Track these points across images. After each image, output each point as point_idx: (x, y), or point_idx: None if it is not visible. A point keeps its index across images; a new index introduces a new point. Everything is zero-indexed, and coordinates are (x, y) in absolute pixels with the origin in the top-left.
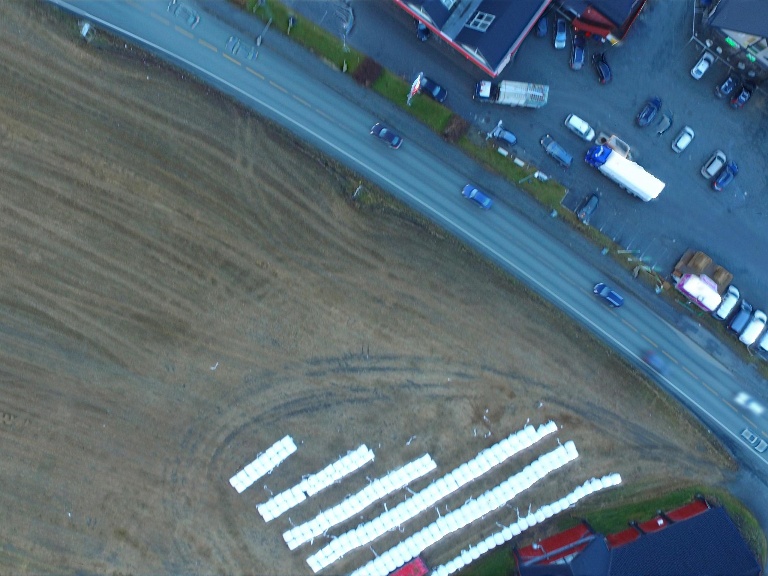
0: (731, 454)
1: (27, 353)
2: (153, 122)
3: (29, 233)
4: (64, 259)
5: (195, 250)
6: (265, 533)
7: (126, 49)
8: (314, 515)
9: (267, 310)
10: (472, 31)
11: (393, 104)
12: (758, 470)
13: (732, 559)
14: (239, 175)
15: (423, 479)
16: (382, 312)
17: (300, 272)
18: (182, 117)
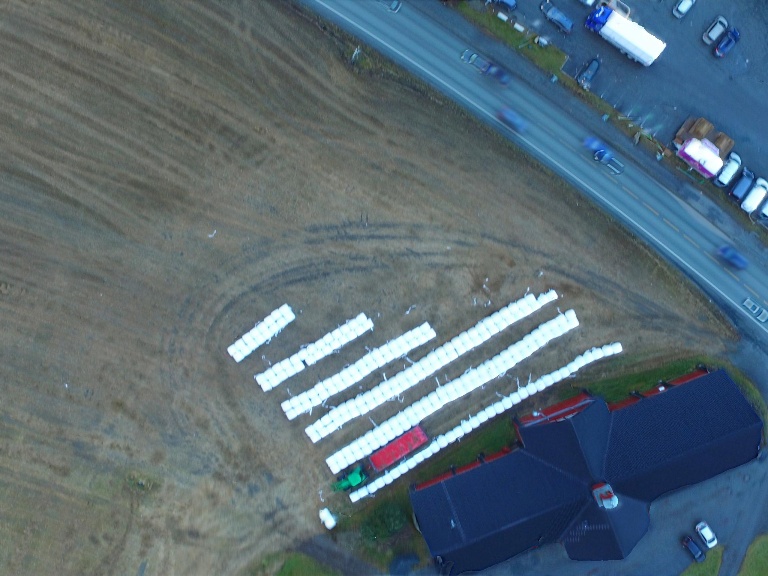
0: (733, 324)
1: (24, 221)
2: None
3: (25, 97)
4: (61, 124)
5: (193, 115)
6: (263, 404)
7: None
8: (313, 384)
9: (265, 177)
10: None
11: None
12: (760, 340)
13: (734, 416)
14: (237, 39)
15: (422, 348)
16: (381, 179)
17: (298, 138)
18: None
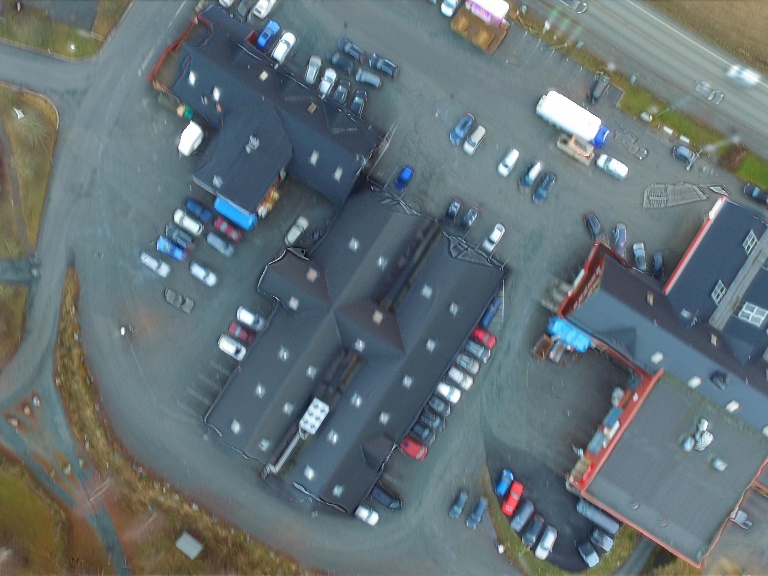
0: None
1: None
2: None
3: None
4: None
5: None
6: None
7: None
8: None
9: None
10: None
11: None
12: None
13: None
14: None
15: None
16: None
17: None
18: None
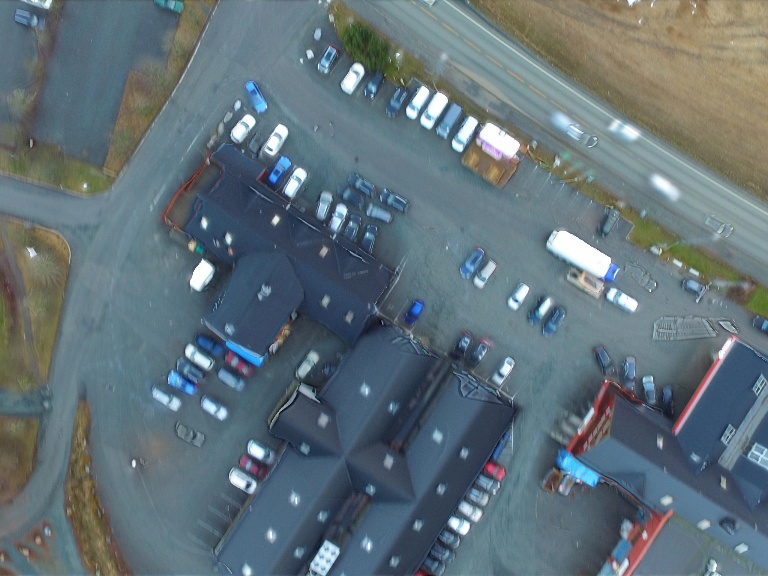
0: None
1: None
2: None
3: None
4: None
5: None
6: None
7: None
8: None
9: None
10: None
11: None
12: None
13: None
14: None
15: None
16: None
17: None
18: None
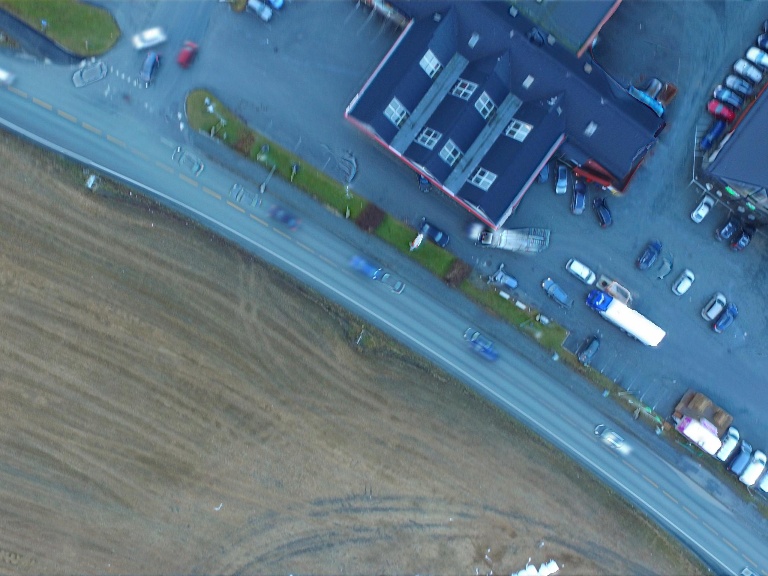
0: None
1: (33, 494)
2: (158, 268)
3: (35, 378)
4: (70, 403)
5: (199, 394)
6: None
7: (131, 197)
8: None
9: (271, 452)
10: (474, 188)
11: (395, 250)
12: None
13: None
14: (243, 320)
15: None
16: (385, 453)
17: (303, 415)
18: (186, 263)
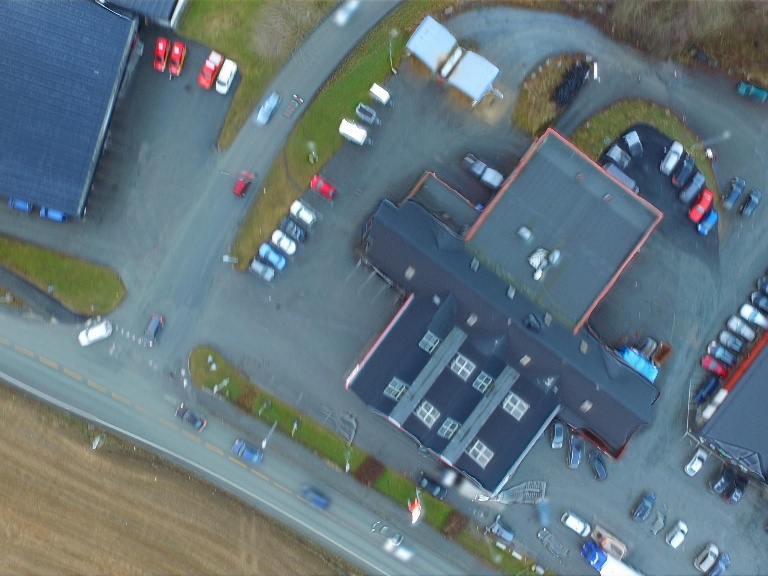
0: None
1: None
2: (160, 522)
3: None
4: None
5: None
6: None
7: (135, 452)
8: None
9: None
10: (471, 462)
11: (394, 503)
12: None
13: None
14: (244, 571)
15: None
16: None
17: None
18: (189, 516)
